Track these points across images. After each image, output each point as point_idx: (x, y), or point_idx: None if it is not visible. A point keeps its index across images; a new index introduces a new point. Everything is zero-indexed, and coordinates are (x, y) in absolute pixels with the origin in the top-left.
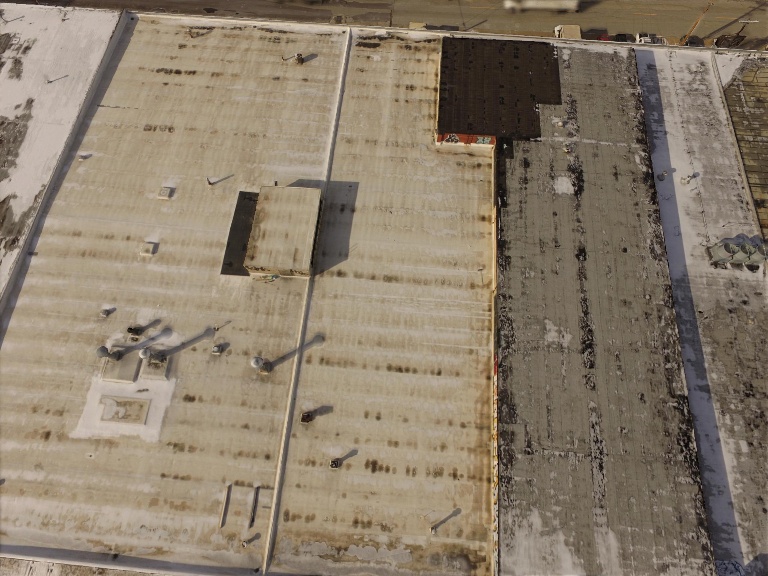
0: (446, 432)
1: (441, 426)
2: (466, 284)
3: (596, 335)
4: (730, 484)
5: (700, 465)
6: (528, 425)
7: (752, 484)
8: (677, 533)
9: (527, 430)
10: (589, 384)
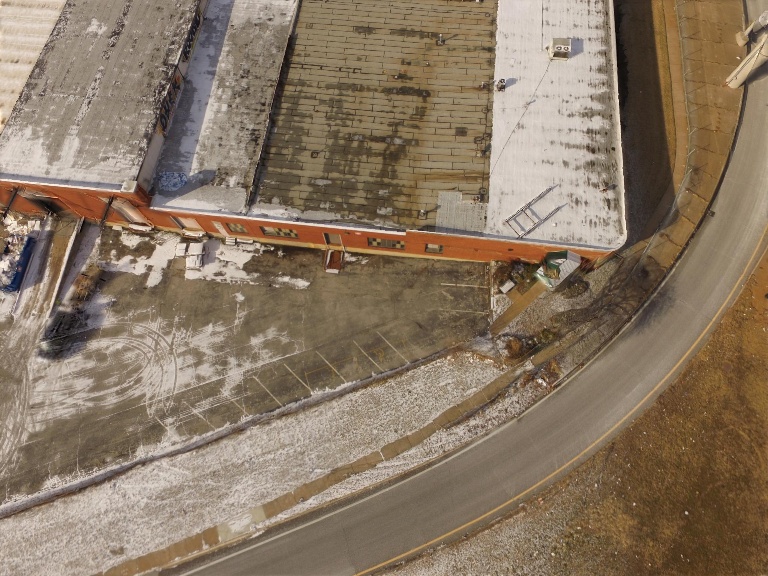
0: (7, 97)
1: (5, 93)
2: (60, 7)
3: (126, 27)
4: (202, 129)
5: (186, 118)
6: (49, 79)
7: (219, 130)
8: (125, 140)
9: (47, 82)
10: (105, 56)
